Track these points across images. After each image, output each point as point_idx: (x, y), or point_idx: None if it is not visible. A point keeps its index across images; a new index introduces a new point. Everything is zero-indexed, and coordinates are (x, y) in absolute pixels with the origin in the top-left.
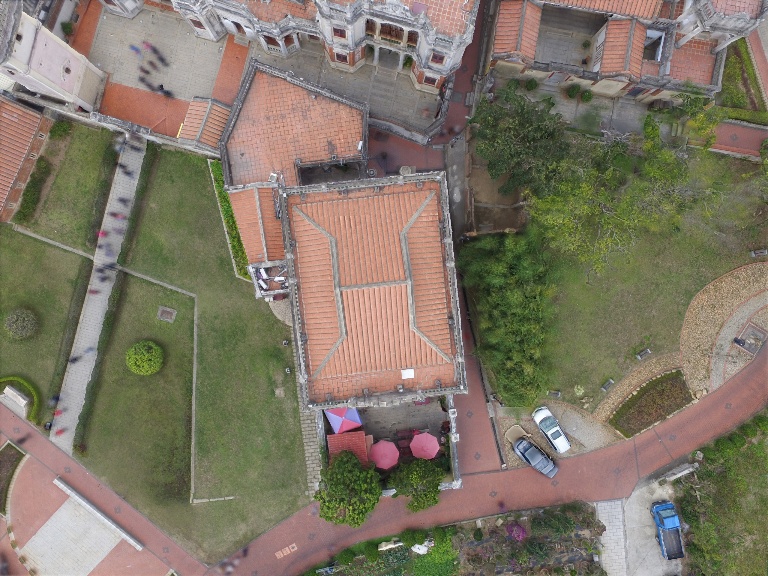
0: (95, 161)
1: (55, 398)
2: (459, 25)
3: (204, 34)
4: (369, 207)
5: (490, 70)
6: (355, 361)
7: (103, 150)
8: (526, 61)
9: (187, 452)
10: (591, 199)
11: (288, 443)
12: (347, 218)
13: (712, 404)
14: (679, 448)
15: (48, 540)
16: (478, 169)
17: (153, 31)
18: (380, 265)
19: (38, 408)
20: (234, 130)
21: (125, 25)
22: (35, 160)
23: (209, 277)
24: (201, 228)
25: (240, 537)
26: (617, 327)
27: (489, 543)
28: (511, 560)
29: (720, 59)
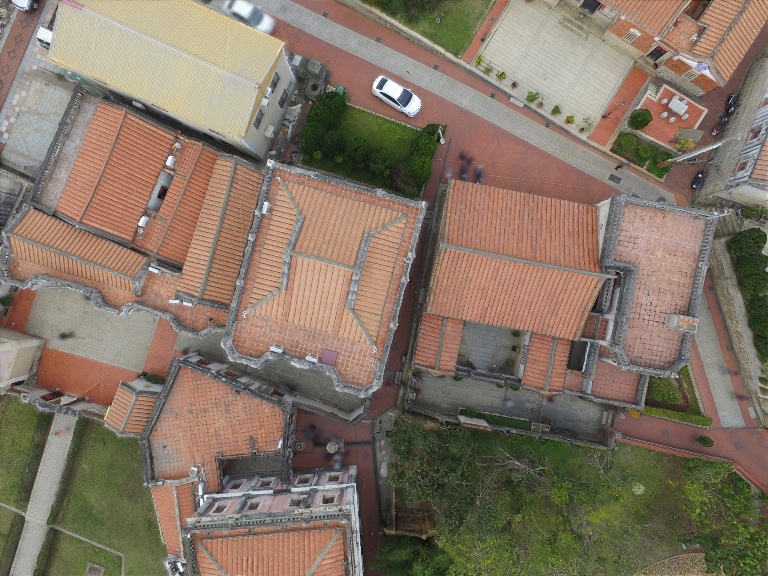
0: (30, 421)
1: None
2: (368, 371)
3: None
4: (274, 546)
5: None
6: None
7: (38, 411)
8: (446, 374)
9: None
10: (498, 546)
11: None
12: (250, 559)
13: None
14: None
15: None
16: None
17: (90, 299)
18: None
19: None
20: (157, 423)
21: (63, 293)
22: None
23: (137, 539)
24: (130, 490)
25: None
26: None
27: None
28: None
29: (644, 377)
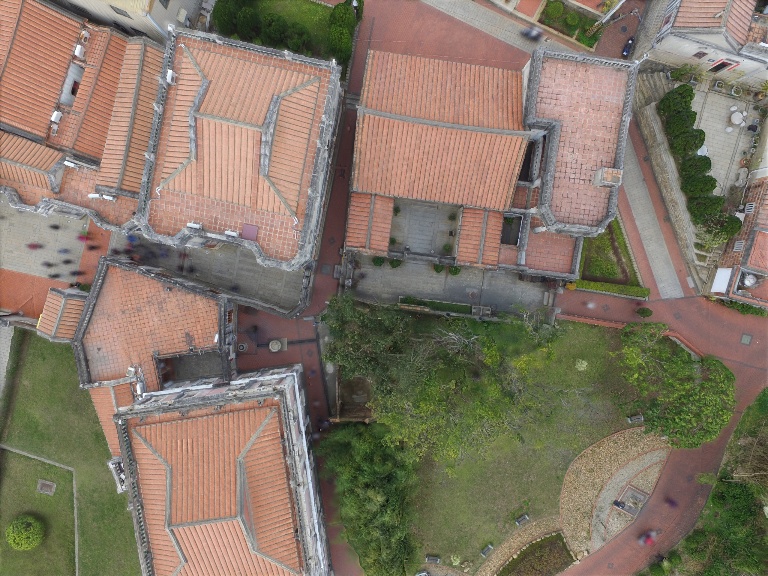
0: None
1: None
2: (291, 244)
3: None
4: (208, 428)
5: None
6: None
7: None
8: (378, 254)
9: None
10: (433, 413)
11: None
12: (185, 442)
13: (594, 564)
14: None
15: None
16: None
17: (15, 211)
18: (213, 498)
19: None
20: (89, 325)
21: None
22: None
23: (85, 452)
24: (75, 404)
25: None
26: (495, 493)
27: None
28: None
29: (578, 245)
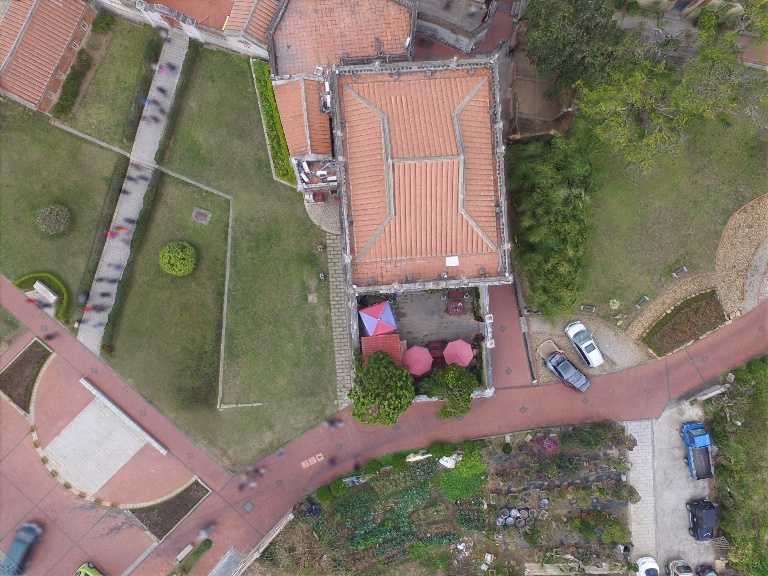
0: (136, 57)
1: (85, 296)
2: None
3: None
4: (421, 89)
5: None
6: (401, 244)
7: (144, 46)
8: None
9: (216, 356)
10: (643, 91)
11: (319, 350)
12: (399, 98)
13: (745, 326)
14: (710, 370)
15: (71, 441)
16: (520, 80)
17: None
18: (432, 142)
19: (67, 305)
20: (281, 22)
21: None
22: (76, 51)
23: (246, 179)
24: (240, 129)
25: (266, 445)
26: (653, 244)
27: None
28: (540, 473)
29: None
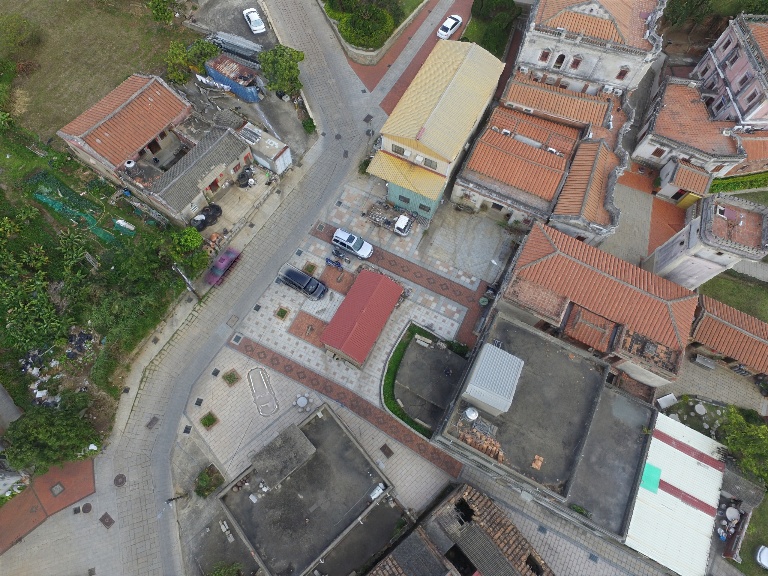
0: (711, 280)
1: None
2: (648, 1)
3: None
4: None
5: None
6: None
7: None
8: None
9: None
10: None
11: None
12: None
13: None
14: None
15: None
16: None
17: None
18: None
19: None
20: None
21: None
22: None
23: None
24: None
25: None
26: None
27: None
28: None
29: None
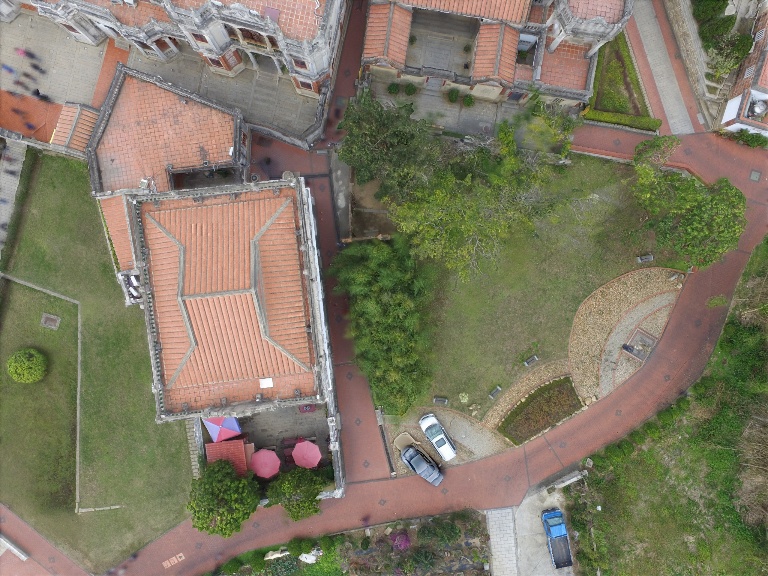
0: None
1: None
2: (312, 30)
3: (82, 38)
4: (223, 214)
5: (367, 75)
6: (210, 370)
7: None
8: (395, 66)
9: (72, 461)
10: (449, 206)
11: (174, 451)
12: (199, 226)
13: (602, 411)
14: (570, 455)
15: None
16: None
17: (32, 35)
18: (226, 273)
19: None
20: (104, 136)
21: (3, 29)
22: None
23: (92, 284)
24: (83, 234)
25: (127, 547)
26: (504, 334)
27: (378, 552)
28: (396, 569)
29: (592, 64)
